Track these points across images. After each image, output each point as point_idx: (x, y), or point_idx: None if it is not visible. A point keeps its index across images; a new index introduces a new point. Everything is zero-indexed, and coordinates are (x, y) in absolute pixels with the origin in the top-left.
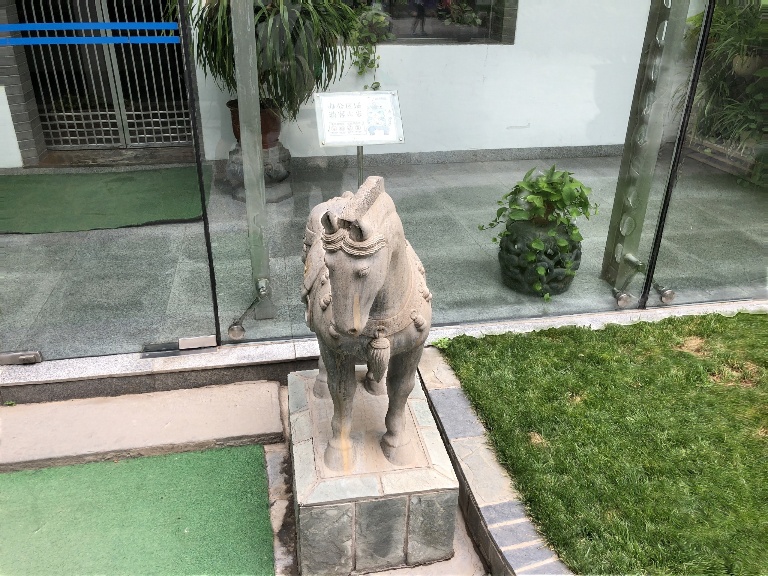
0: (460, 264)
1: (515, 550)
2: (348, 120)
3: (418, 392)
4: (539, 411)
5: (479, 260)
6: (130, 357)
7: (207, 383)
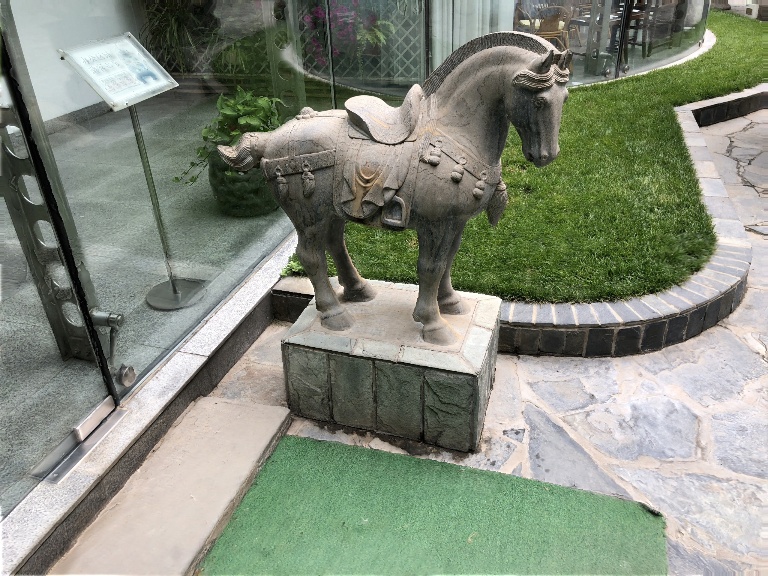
0: (172, 224)
1: (538, 317)
2: (112, 73)
3: (382, 282)
4: None
5: (180, 214)
6: (40, 493)
7: (150, 447)
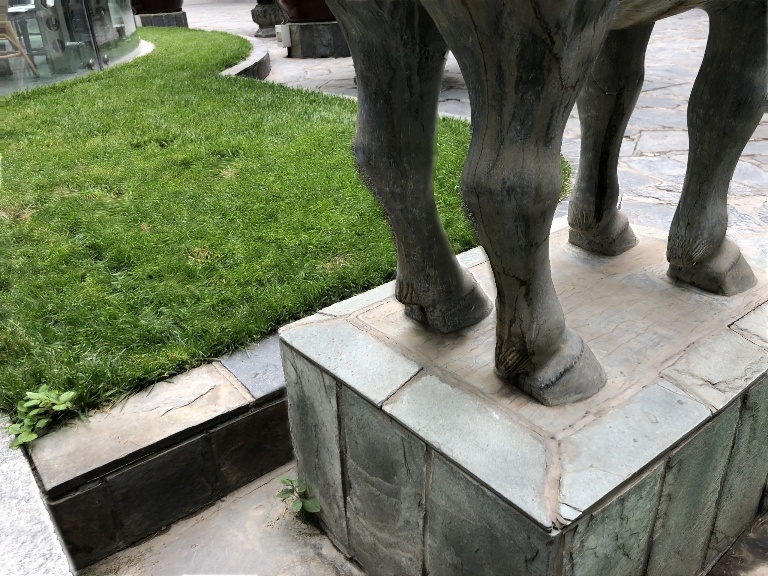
0: None
1: None
2: None
3: None
4: (275, 260)
5: None
6: None
7: None
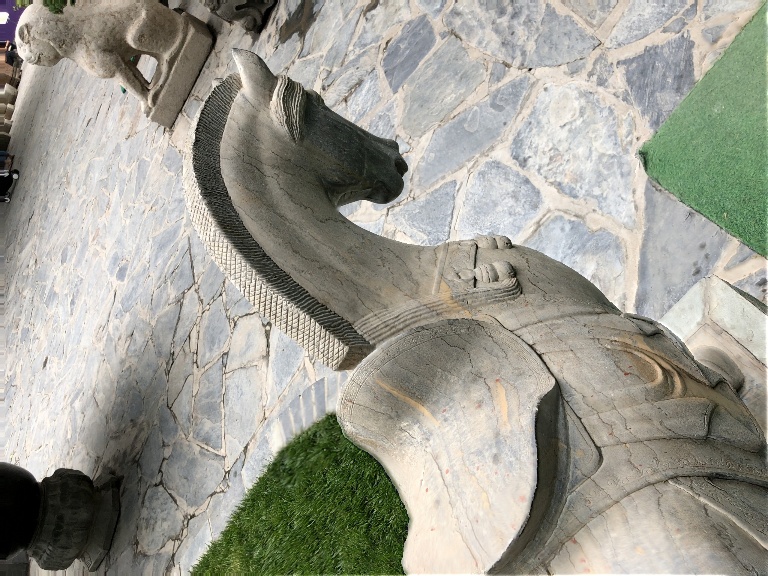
0: None
1: None
2: None
3: None
4: None
5: None
6: None
7: None
